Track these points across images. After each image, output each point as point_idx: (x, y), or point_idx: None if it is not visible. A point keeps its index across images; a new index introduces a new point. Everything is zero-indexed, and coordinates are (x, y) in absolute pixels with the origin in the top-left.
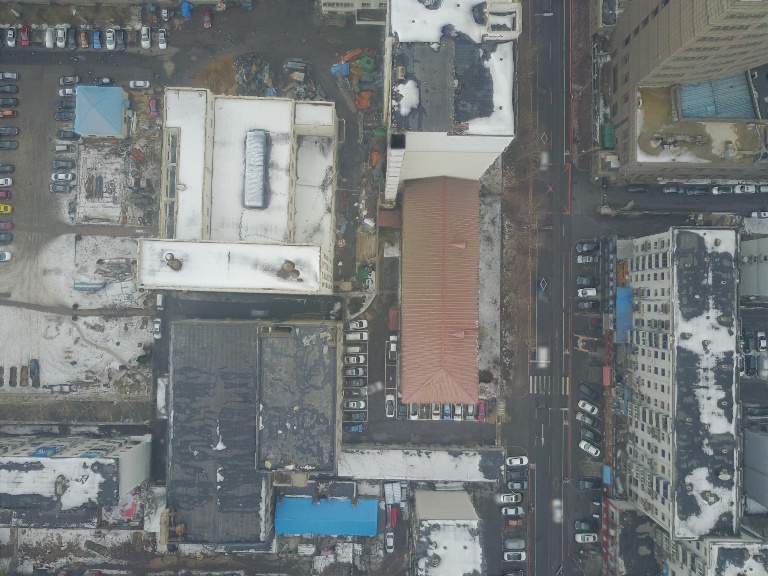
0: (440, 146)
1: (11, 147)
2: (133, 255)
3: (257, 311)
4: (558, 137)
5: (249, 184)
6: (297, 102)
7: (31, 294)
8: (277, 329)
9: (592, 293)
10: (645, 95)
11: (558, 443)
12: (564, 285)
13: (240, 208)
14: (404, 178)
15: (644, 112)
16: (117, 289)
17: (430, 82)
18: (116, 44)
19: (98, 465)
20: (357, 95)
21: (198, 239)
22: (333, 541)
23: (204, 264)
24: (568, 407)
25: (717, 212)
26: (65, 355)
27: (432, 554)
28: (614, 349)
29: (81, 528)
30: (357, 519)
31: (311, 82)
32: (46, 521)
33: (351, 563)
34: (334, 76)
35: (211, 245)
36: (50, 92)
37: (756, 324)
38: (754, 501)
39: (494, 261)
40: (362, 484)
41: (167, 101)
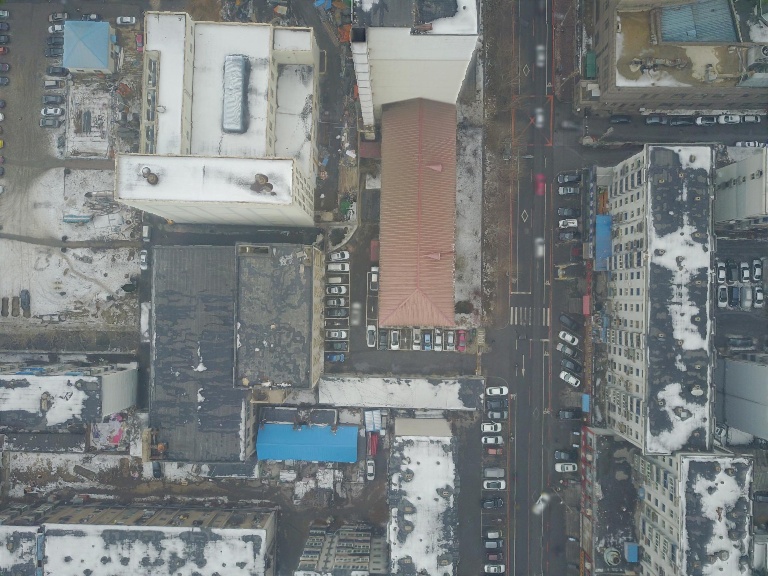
0: (407, 52)
1: (2, 83)
2: None
3: (240, 242)
4: (540, 69)
5: (227, 107)
6: (276, 28)
7: (22, 226)
8: (256, 252)
9: (573, 224)
10: (624, 19)
11: (538, 374)
12: (545, 217)
13: (219, 132)
14: (381, 102)
15: (623, 36)
16: (105, 221)
17: None
18: None
19: (82, 382)
20: (339, 28)
21: None
22: (315, 468)
23: (180, 178)
24: (549, 338)
25: None
26: (55, 286)
27: (406, 469)
28: (594, 278)
29: (70, 452)
30: (337, 444)
31: (294, 16)
32: (36, 445)
33: (332, 489)
34: (317, 10)
35: (186, 159)
36: (40, 29)
37: (740, 255)
38: (736, 432)
39: (475, 193)
40: (343, 413)
41: (147, 25)
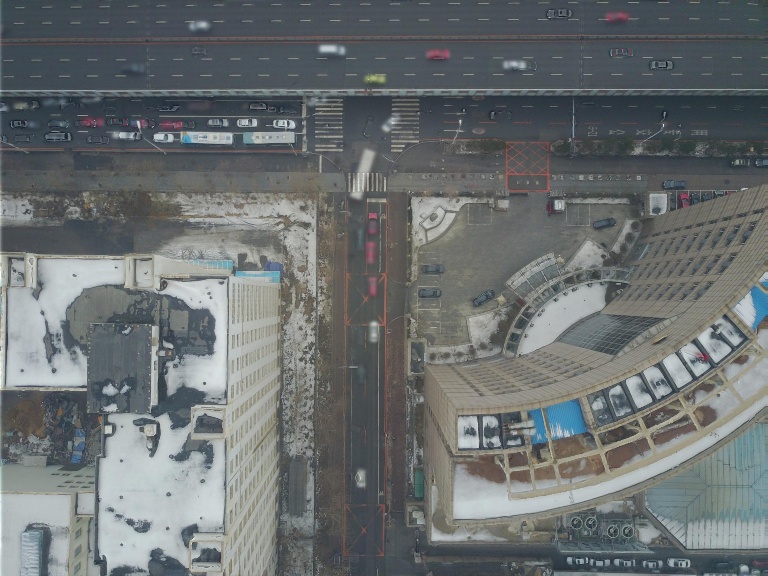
0: None
1: None
2: None
3: None
4: (372, 477)
5: None
6: (78, 492)
7: None
8: None
9: None
10: None
11: None
12: None
13: None
14: None
15: None
16: None
17: None
18: None
19: None
20: None
21: None
22: None
23: None
24: None
25: (529, 561)
26: None
27: None
28: None
29: None
30: None
31: None
32: None
33: None
34: None
35: None
36: None
37: None
38: None
39: None
40: None
41: None
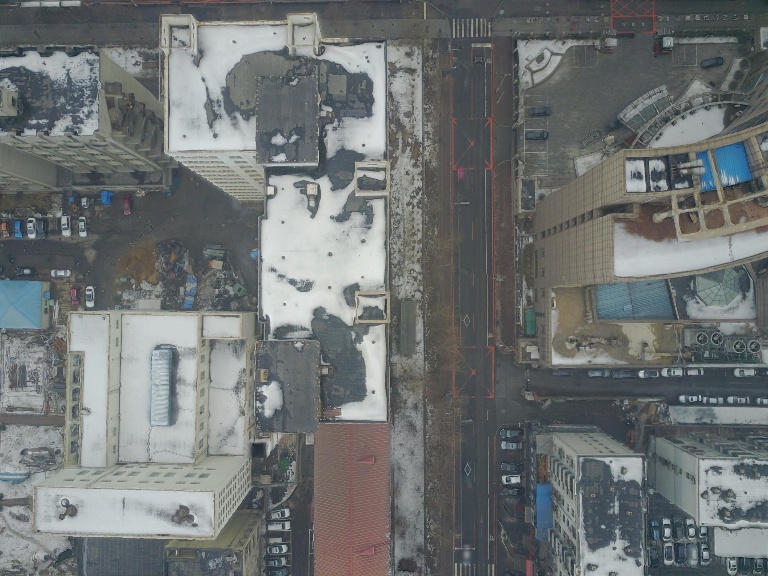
0: None
1: None
2: (57, 444)
3: None
4: (481, 319)
5: (154, 405)
6: (204, 315)
7: None
8: None
9: (516, 481)
10: (559, 296)
11: None
12: (489, 470)
13: (148, 424)
14: None
15: (558, 313)
16: (41, 479)
17: (294, 383)
18: (37, 233)
19: None
20: None
21: (93, 485)
22: None
23: (99, 510)
24: None
25: (642, 398)
26: None
27: None
28: (536, 544)
29: None
30: None
31: (231, 268)
32: None
33: None
34: (254, 261)
35: (106, 491)
36: None
37: None
38: None
39: (417, 447)
40: None
41: (70, 325)
